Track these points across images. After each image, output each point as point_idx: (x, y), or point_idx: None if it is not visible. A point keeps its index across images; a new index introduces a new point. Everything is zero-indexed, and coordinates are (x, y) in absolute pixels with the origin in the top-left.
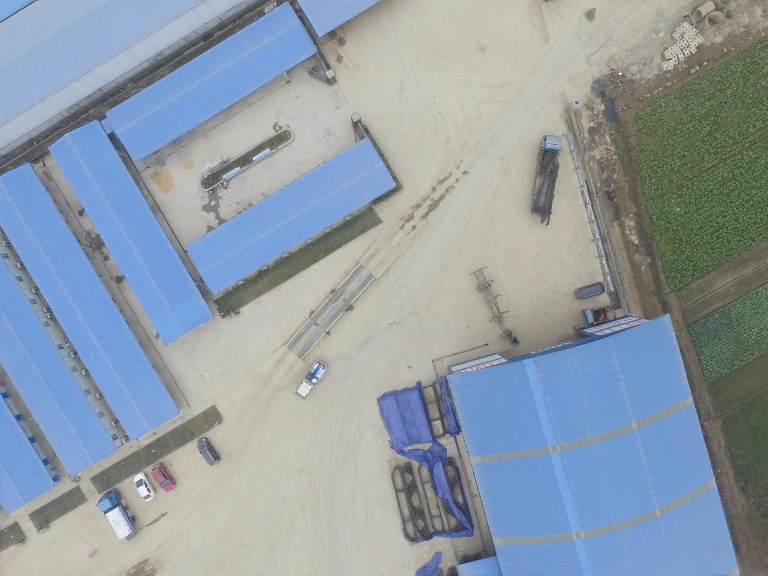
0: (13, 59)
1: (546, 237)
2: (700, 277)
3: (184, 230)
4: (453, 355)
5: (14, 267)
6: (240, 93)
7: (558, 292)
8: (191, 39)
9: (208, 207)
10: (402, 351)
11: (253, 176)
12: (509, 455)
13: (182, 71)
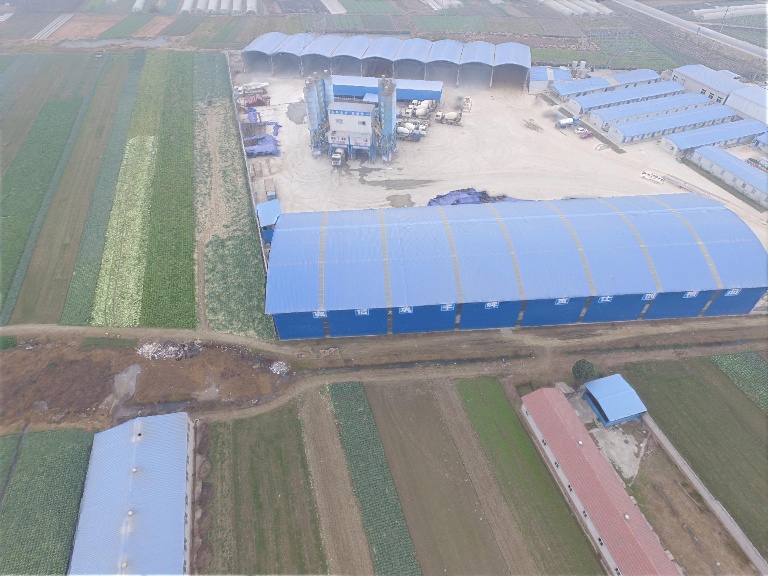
0: None
1: None
2: None
3: None
4: None
5: None
6: None
7: None
8: None
9: None
10: None
11: None
12: None
13: None
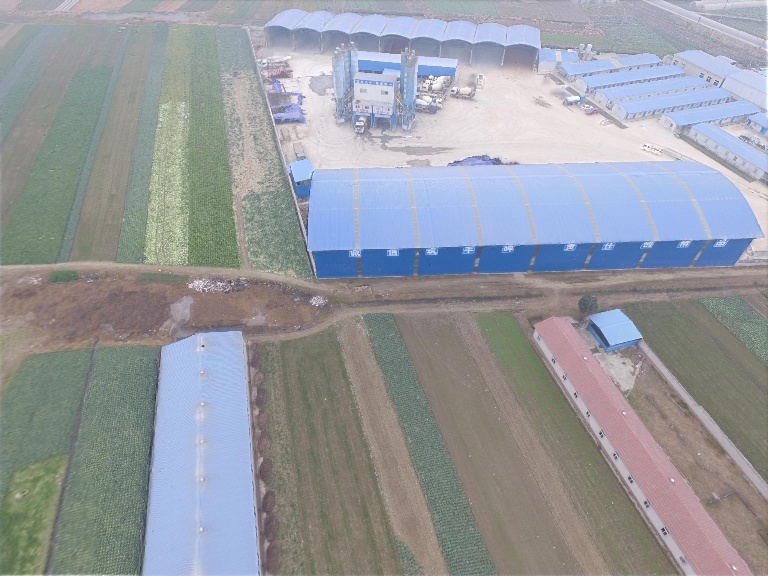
0: None
1: None
2: None
3: None
4: None
5: None
6: None
7: None
8: None
9: None
10: None
11: None
12: None
13: None
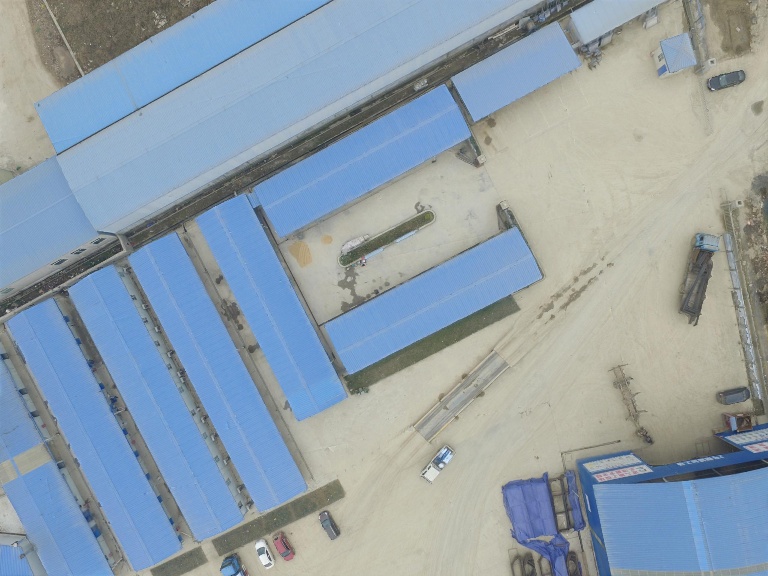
0: (173, 135)
1: (690, 336)
2: None
3: (319, 304)
4: (583, 449)
5: (152, 331)
6: (389, 175)
7: (698, 393)
8: (340, 114)
9: (344, 283)
10: (531, 441)
11: (391, 255)
12: (656, 573)
13: (332, 149)
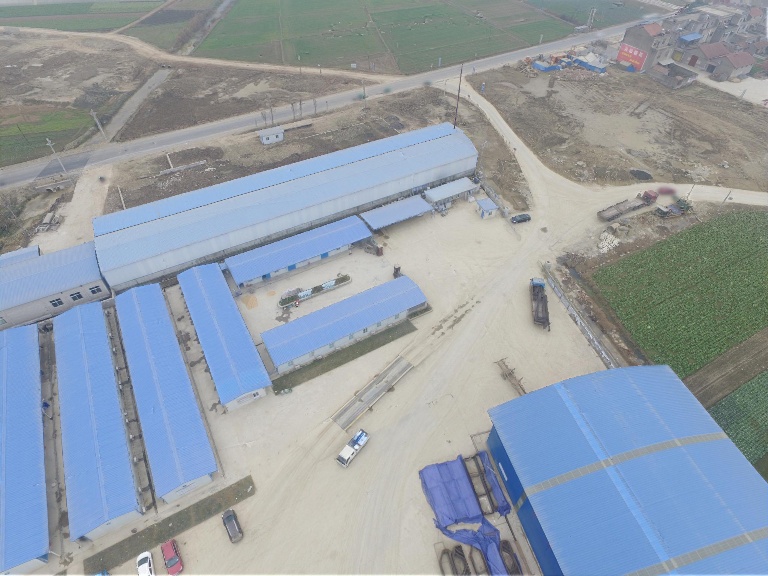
0: (180, 226)
1: (551, 342)
2: (692, 374)
3: (258, 332)
4: (490, 431)
5: (110, 349)
6: (319, 252)
7: None
8: (290, 232)
9: (280, 318)
10: (441, 427)
11: (319, 301)
12: (564, 476)
13: (283, 241)
